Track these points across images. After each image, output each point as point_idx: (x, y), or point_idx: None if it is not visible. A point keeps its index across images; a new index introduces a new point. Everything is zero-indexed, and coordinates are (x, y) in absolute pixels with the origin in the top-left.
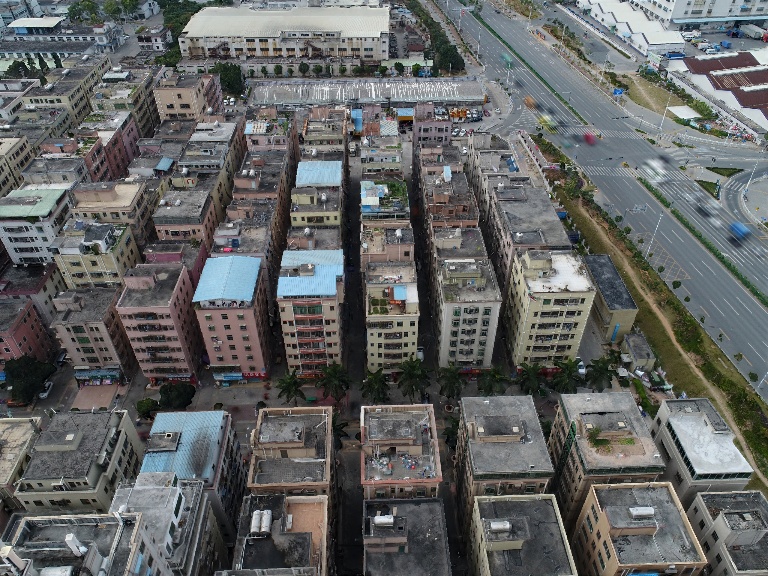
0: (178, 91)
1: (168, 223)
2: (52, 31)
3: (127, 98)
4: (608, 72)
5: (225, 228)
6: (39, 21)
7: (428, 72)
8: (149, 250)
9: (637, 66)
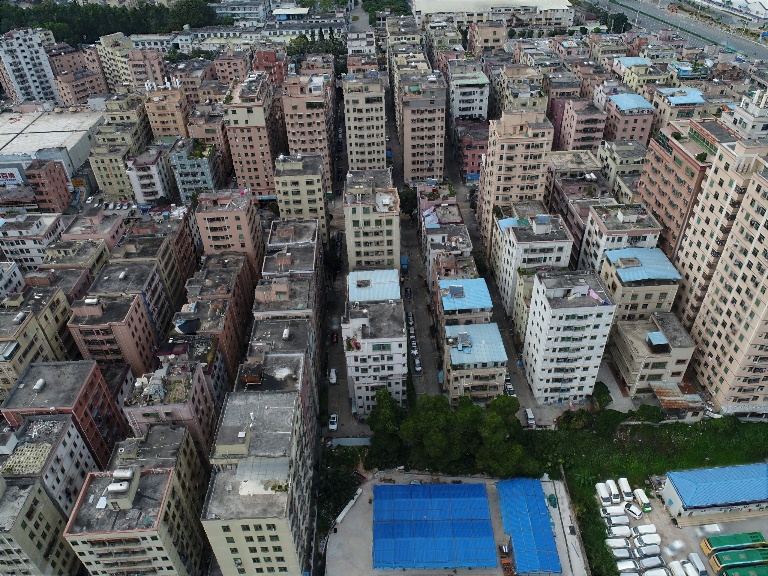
0: (495, 29)
1: (560, 87)
2: (303, 17)
3: (458, 36)
4: (742, 28)
5: (610, 82)
6: (293, 10)
7: (605, 33)
8: (559, 99)
9: (760, 25)
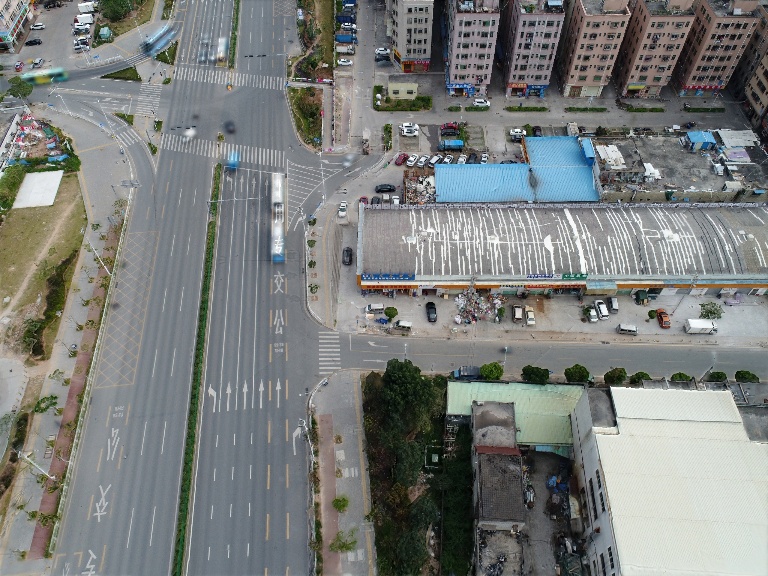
0: None
1: None
2: None
3: None
4: None
5: None
6: None
7: None
8: None
9: None
